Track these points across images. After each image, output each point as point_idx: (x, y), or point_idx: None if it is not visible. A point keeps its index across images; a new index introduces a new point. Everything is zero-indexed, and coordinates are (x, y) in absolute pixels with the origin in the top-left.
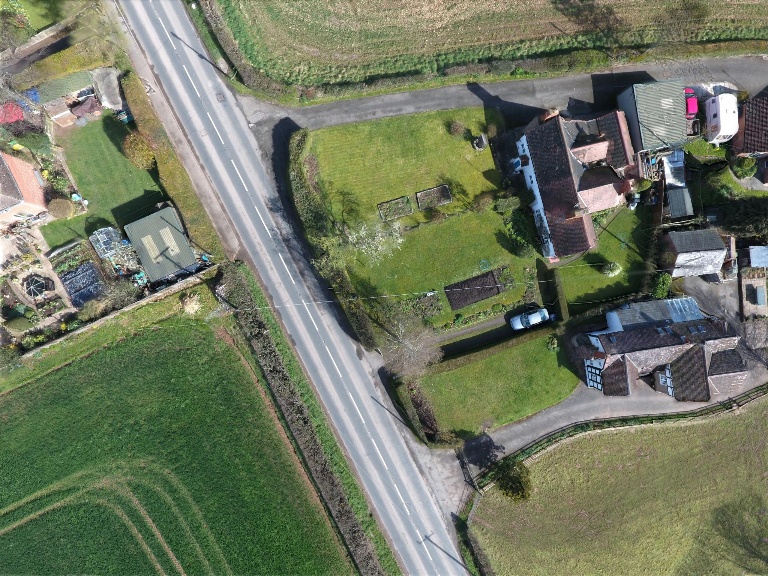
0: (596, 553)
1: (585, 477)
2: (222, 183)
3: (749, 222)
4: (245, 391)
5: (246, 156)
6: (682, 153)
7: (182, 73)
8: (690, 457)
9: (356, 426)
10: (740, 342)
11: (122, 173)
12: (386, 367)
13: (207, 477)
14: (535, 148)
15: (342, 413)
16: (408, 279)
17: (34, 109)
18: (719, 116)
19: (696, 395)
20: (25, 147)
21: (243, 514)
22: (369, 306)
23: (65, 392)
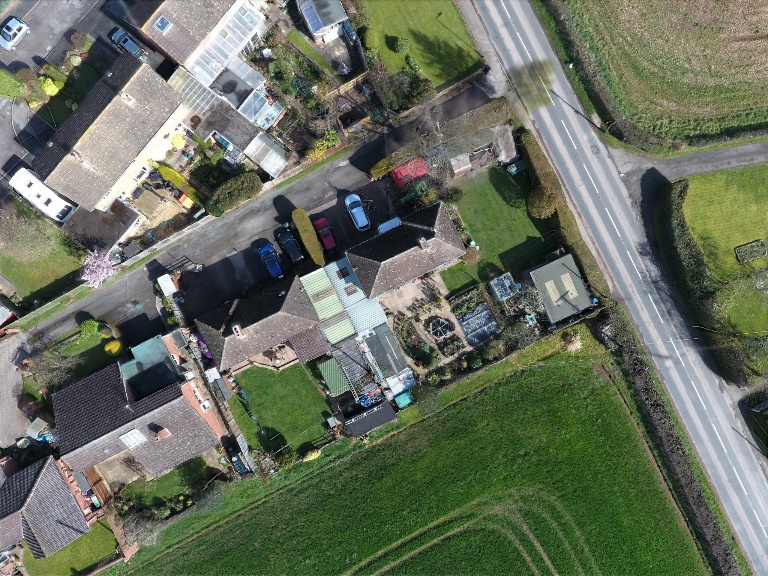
0: None
1: None
2: (597, 229)
3: None
4: (623, 423)
5: (618, 204)
6: None
7: (560, 127)
8: None
9: (719, 455)
10: None
11: (507, 221)
12: (744, 399)
13: (590, 504)
14: None
15: (706, 443)
16: (764, 317)
17: (435, 163)
18: None
19: None
20: None
21: (622, 538)
22: None
23: (464, 425)
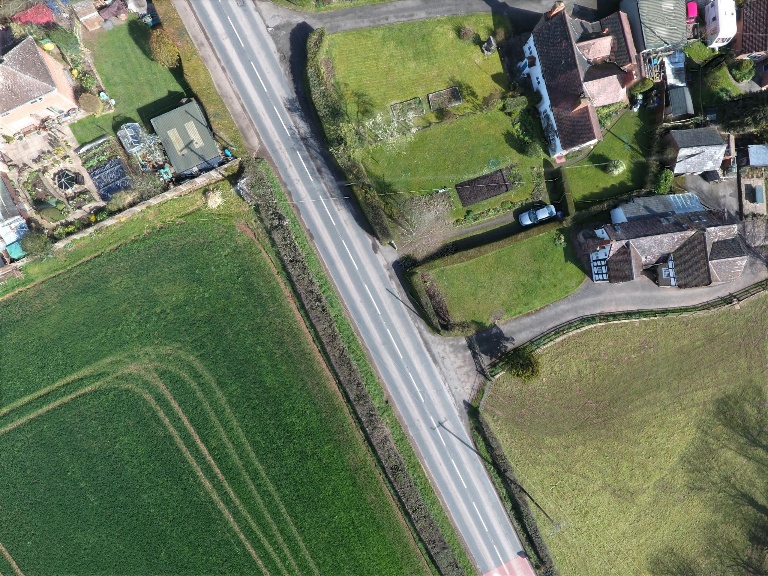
0: (603, 441)
1: (592, 368)
2: (242, 84)
3: (747, 114)
4: (266, 282)
5: (265, 58)
6: (683, 54)
7: None
8: (692, 350)
9: (372, 317)
10: (740, 236)
11: (147, 74)
12: (400, 261)
13: (230, 364)
14: (542, 45)
15: (358, 304)
16: (421, 176)
17: (63, 12)
18: (718, 18)
19: (698, 280)
20: (55, 47)
21: (265, 399)
22: (383, 202)
23: (95, 282)
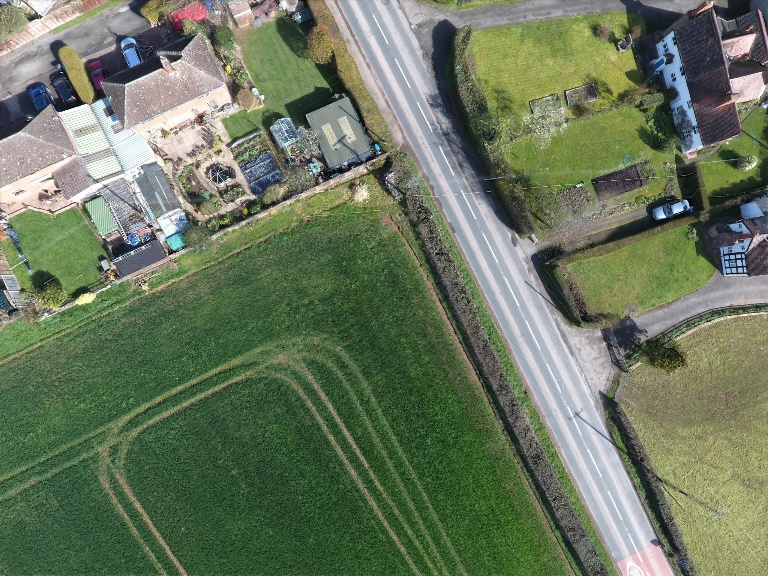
0: (733, 432)
1: (722, 360)
2: (387, 80)
3: None
4: (410, 274)
5: (408, 55)
6: None
7: None
8: None
9: (511, 309)
10: None
11: (294, 71)
12: (538, 254)
13: (376, 354)
14: (684, 43)
15: (498, 296)
16: (558, 171)
17: (216, 9)
18: None
19: None
20: (209, 44)
21: (409, 389)
22: None
23: (246, 273)
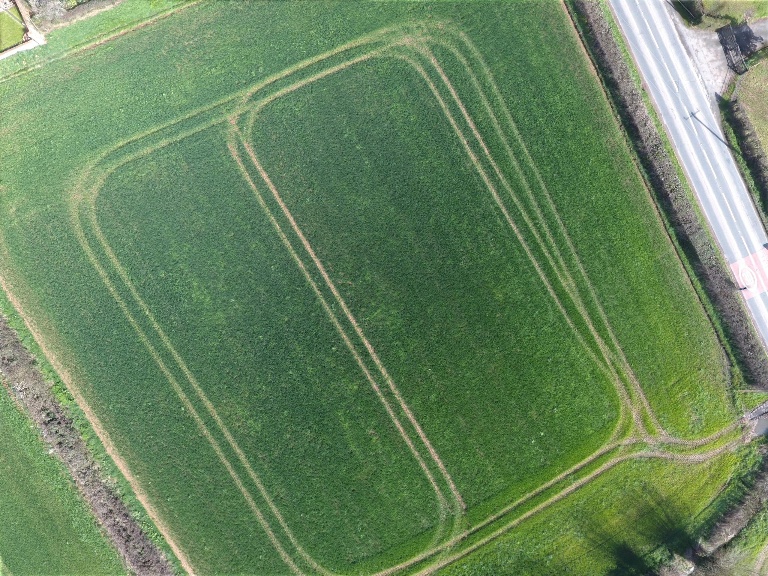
0: None
1: None
2: None
3: None
4: None
5: None
6: None
7: None
8: None
9: (631, 6)
10: None
11: None
12: None
13: (498, 41)
14: None
15: None
16: None
17: None
18: None
19: None
20: None
21: (530, 77)
22: None
23: None
